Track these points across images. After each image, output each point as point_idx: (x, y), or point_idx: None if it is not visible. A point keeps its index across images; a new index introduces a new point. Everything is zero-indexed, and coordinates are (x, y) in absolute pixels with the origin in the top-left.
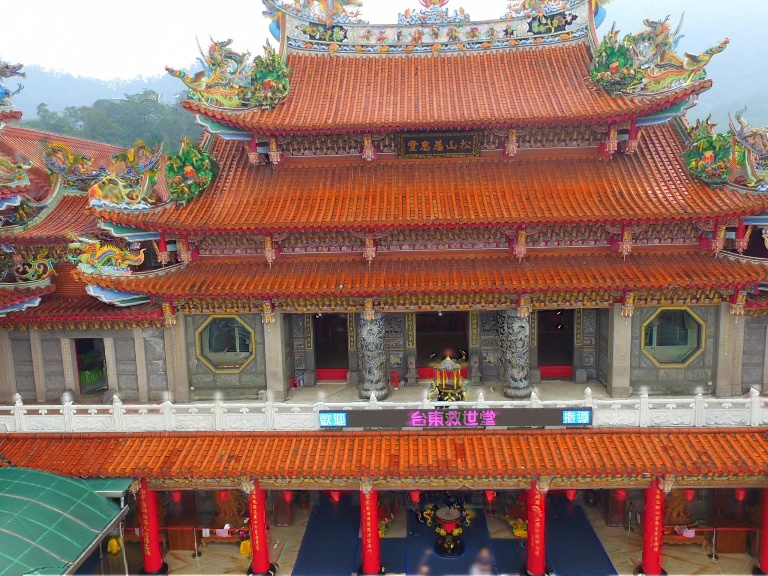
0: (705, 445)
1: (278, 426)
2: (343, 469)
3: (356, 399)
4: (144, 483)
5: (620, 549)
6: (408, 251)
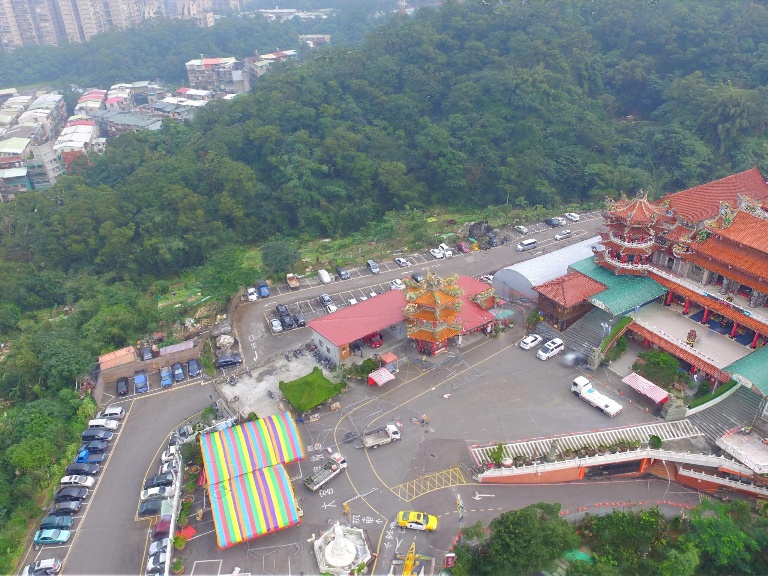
0: (765, 328)
1: (696, 291)
2: (701, 302)
3: (718, 292)
4: (671, 290)
5: (757, 343)
6: (740, 269)
